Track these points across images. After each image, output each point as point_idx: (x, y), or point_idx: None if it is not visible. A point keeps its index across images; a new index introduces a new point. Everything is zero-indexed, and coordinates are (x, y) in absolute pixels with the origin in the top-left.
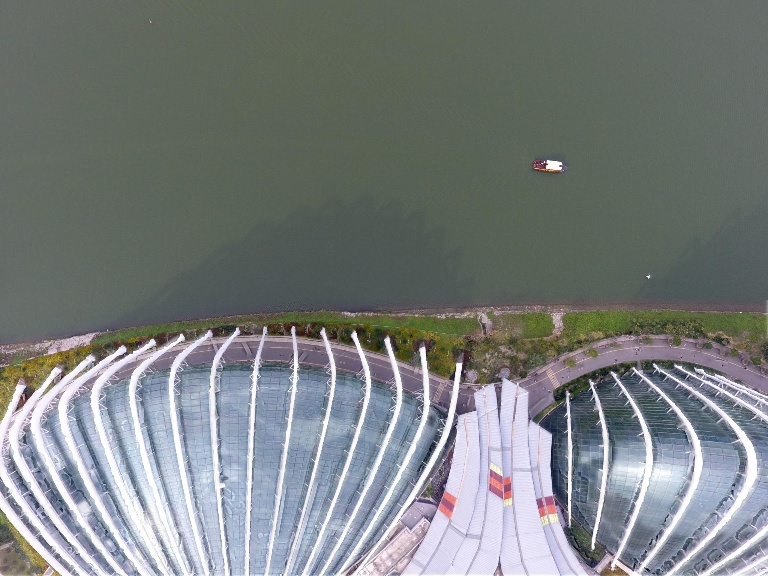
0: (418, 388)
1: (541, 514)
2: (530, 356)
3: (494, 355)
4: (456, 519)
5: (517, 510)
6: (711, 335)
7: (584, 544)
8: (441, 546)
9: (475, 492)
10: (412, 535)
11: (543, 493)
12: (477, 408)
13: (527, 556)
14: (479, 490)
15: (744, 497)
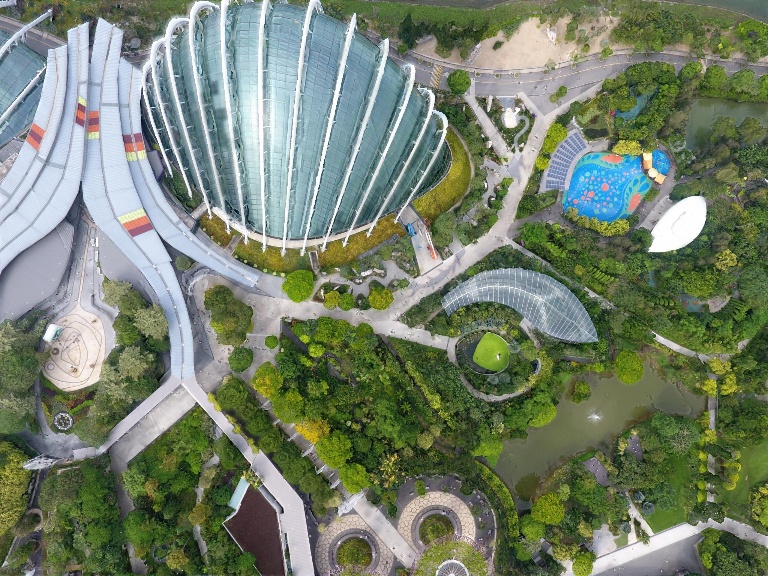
0: (45, 52)
1: (128, 149)
2: (157, 23)
3: (125, 24)
4: (42, 150)
5: (104, 144)
6: (350, 17)
7: (181, 190)
8: (27, 176)
9: (58, 121)
10: (2, 167)
11: (133, 130)
12: (69, 44)
13: (111, 188)
14: (64, 121)
15: (221, 44)
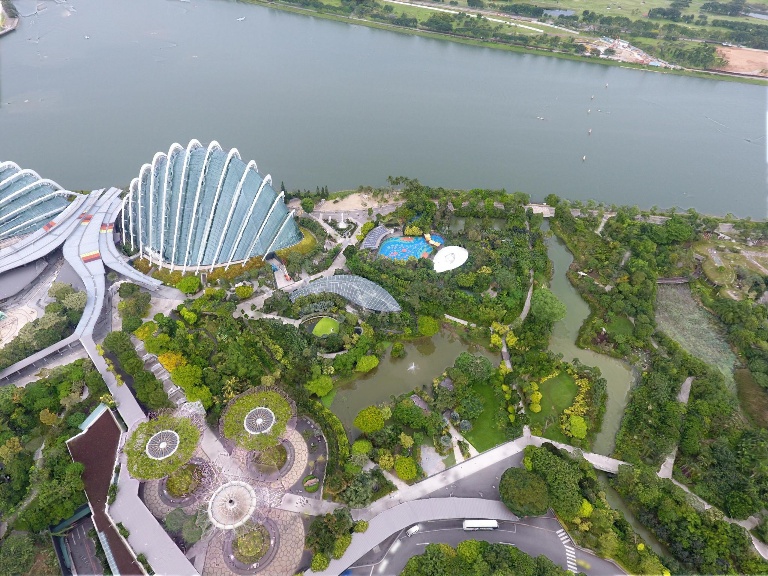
0: None
1: (103, 228)
2: None
3: None
4: None
5: None
6: None
7: None
8: None
9: None
10: None
11: (109, 222)
12: None
13: (83, 243)
14: (71, 218)
15: (168, 158)
